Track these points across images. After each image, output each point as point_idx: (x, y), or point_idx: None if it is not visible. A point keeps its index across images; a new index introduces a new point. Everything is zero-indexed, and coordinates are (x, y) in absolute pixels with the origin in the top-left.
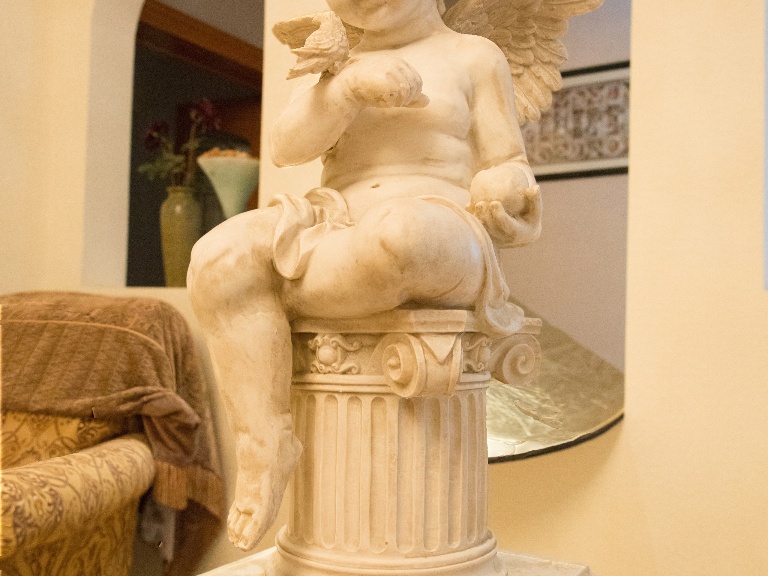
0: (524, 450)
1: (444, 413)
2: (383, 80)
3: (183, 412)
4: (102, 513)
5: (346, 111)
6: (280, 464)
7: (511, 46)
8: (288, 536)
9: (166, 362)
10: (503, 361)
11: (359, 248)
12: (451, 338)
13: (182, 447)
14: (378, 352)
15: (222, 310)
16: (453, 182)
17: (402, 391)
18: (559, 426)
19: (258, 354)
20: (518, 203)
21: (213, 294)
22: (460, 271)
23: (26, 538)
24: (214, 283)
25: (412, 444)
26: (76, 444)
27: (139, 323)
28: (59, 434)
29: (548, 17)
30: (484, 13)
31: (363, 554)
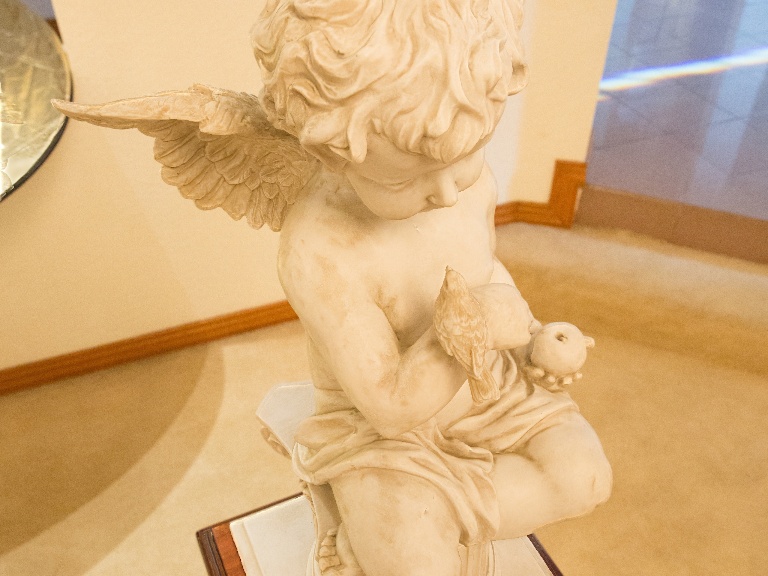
0: (19, 174)
1: None
2: None
3: None
4: None
5: None
6: None
7: None
8: None
9: None
10: None
11: None
12: None
13: None
14: None
15: None
16: None
17: None
18: (21, 119)
19: None
20: None
21: None
22: None
23: None
24: None
25: None
26: None
27: None
28: None
29: None
30: None
31: None
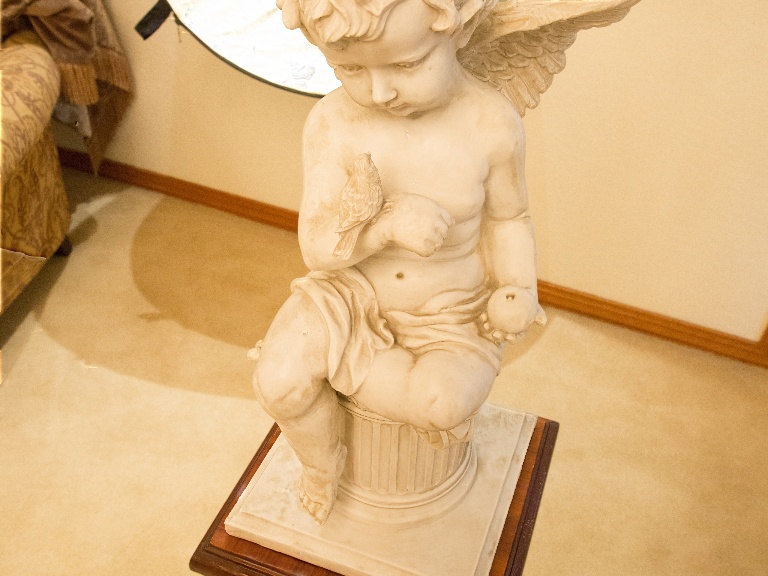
0: None
1: None
2: (421, 248)
3: (73, 9)
4: None
5: None
6: (337, 476)
7: (521, 42)
8: None
9: None
10: None
11: (411, 417)
12: (468, 423)
13: (80, 44)
14: None
15: (292, 419)
16: (465, 256)
17: None
18: None
19: (320, 433)
20: None
21: None
22: None
23: None
24: (286, 411)
25: None
26: None
27: None
28: None
29: (566, 25)
30: None
31: (391, 496)
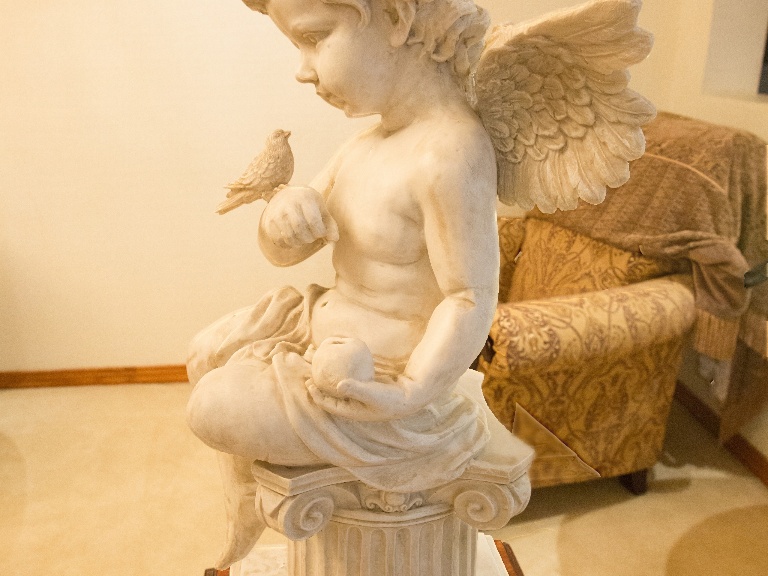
0: None
1: (341, 539)
2: (267, 228)
3: (732, 264)
4: (609, 354)
5: None
6: (242, 520)
7: (568, 100)
8: None
9: (725, 207)
10: (454, 501)
11: None
12: (279, 498)
13: (728, 299)
14: None
15: None
16: (386, 314)
17: None
18: None
19: None
20: (335, 392)
21: None
22: (259, 451)
23: (519, 367)
24: None
25: None
26: (625, 276)
27: (703, 161)
28: (612, 263)
29: (590, 69)
30: (516, 65)
31: None
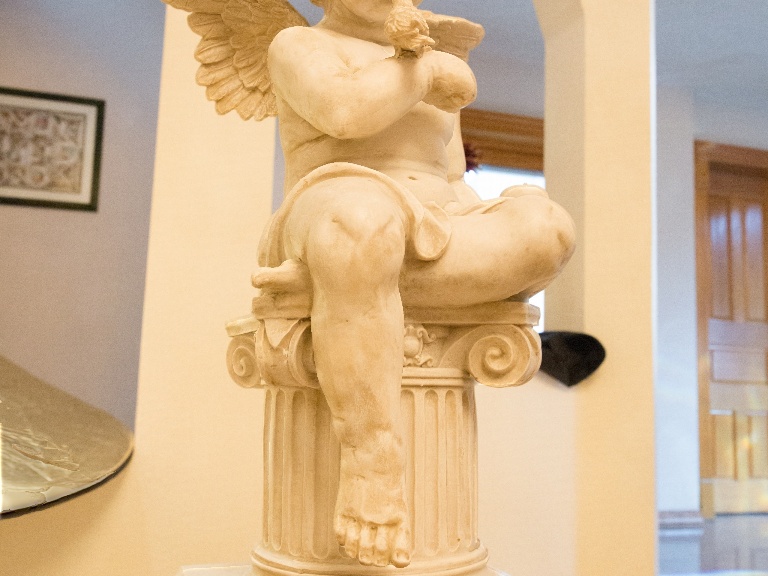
0: (55, 497)
1: None
2: (471, 79)
3: None
4: None
5: (422, 97)
6: None
7: None
8: (323, 561)
9: None
10: None
11: (534, 236)
12: None
13: None
14: (460, 344)
15: (384, 286)
16: None
17: (496, 381)
18: (76, 468)
19: (401, 339)
20: None
21: (384, 266)
22: None
23: None
24: (387, 253)
25: (467, 437)
26: None
27: None
28: None
29: None
30: None
31: (443, 555)
